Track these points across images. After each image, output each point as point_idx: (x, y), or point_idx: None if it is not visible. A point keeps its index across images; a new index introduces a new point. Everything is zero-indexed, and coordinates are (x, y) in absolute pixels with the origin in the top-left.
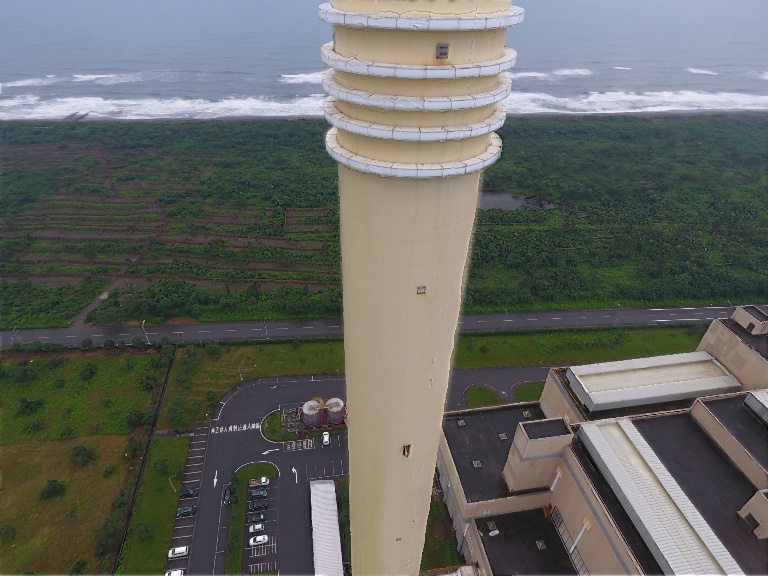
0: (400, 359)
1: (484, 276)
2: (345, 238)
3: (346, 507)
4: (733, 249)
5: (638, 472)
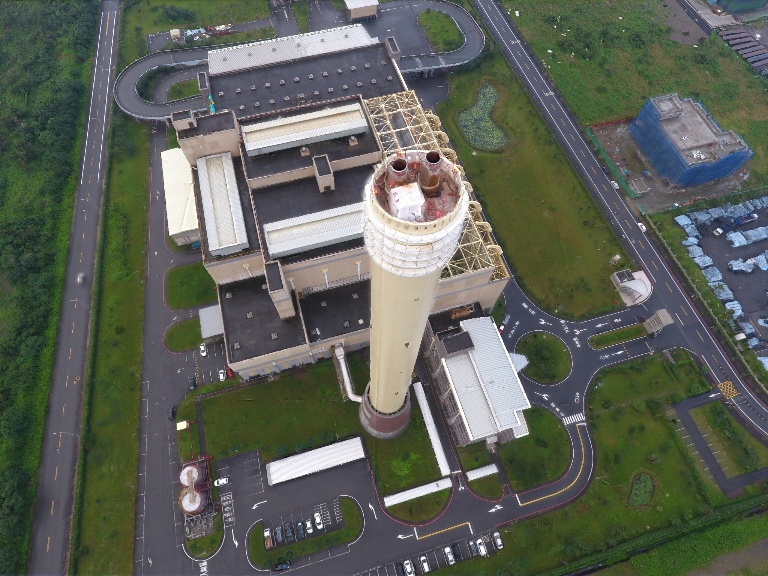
0: None
1: None
2: None
3: (288, 450)
4: (3, 82)
5: (304, 231)
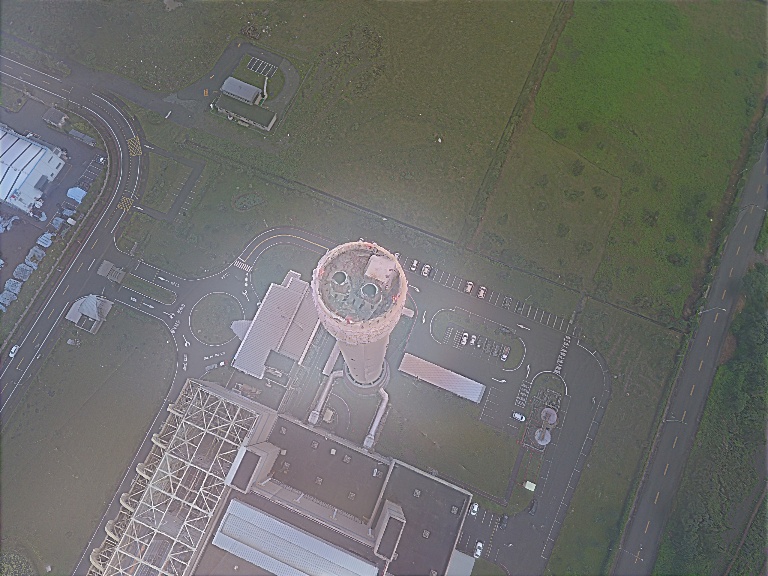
0: None
1: None
2: None
3: None
4: None
5: (327, 571)
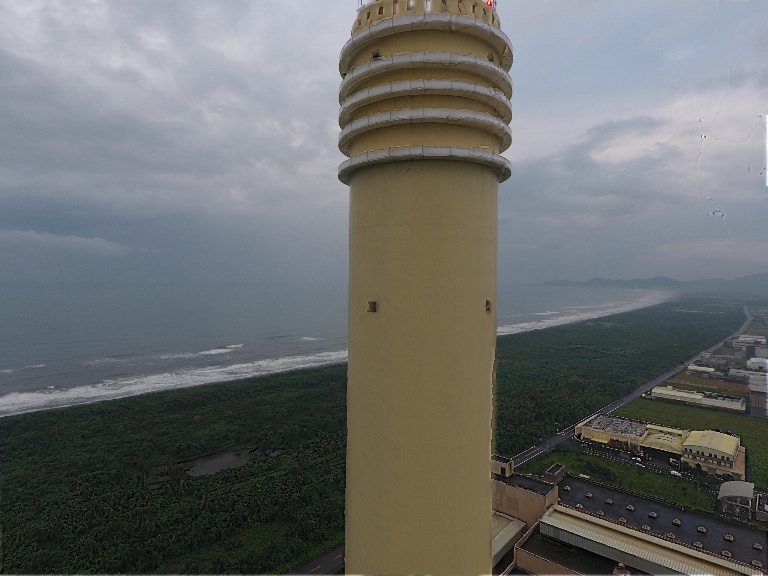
0: (474, 418)
1: (242, 543)
2: (391, 264)
3: None
4: None
5: None
